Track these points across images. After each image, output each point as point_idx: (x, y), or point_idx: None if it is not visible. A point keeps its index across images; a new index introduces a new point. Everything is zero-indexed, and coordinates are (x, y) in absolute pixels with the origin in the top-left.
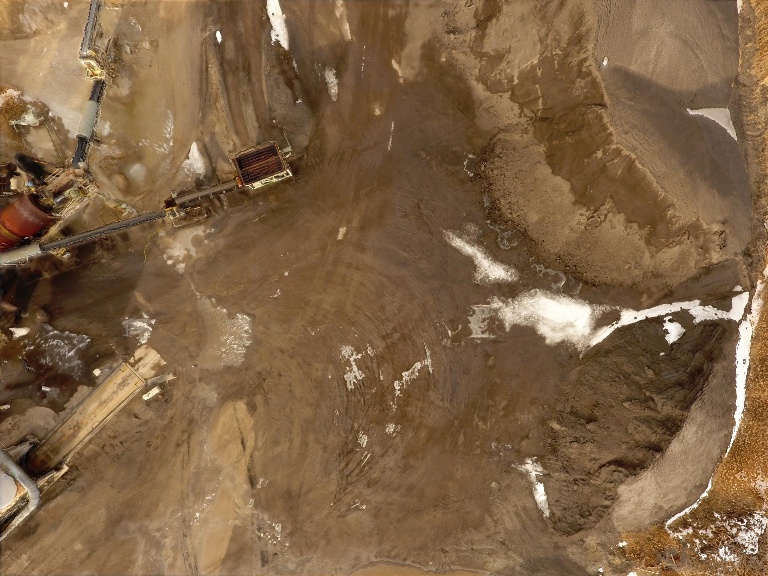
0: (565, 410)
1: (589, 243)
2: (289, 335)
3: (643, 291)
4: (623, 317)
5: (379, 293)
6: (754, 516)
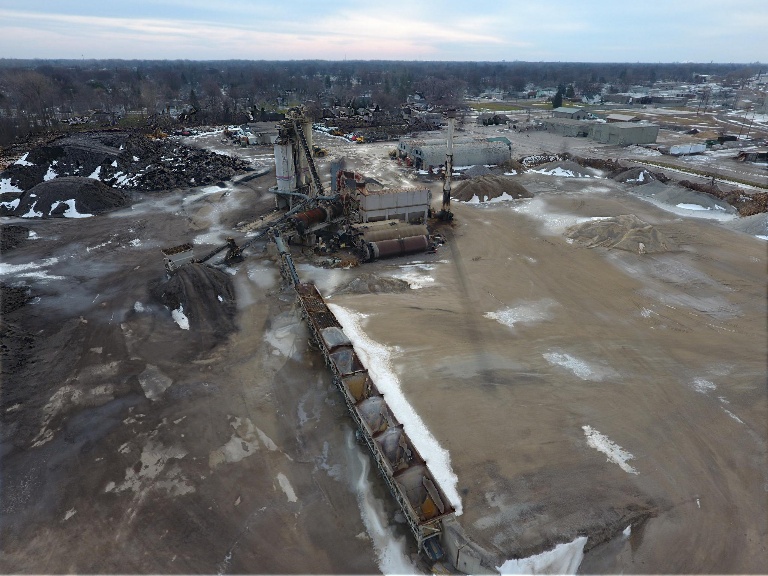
0: (5, 250)
1: None
2: None
3: None
4: None
5: None
6: None
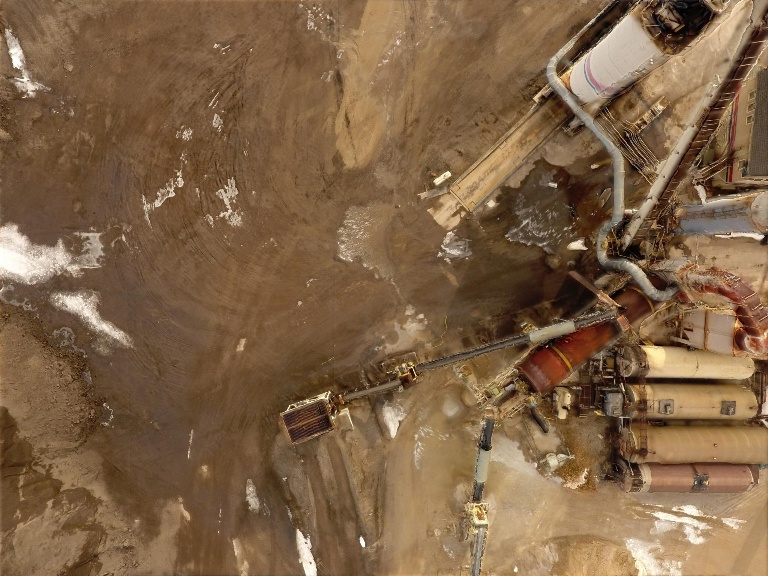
0: None
1: None
2: (297, 238)
3: None
4: None
5: (201, 282)
6: None
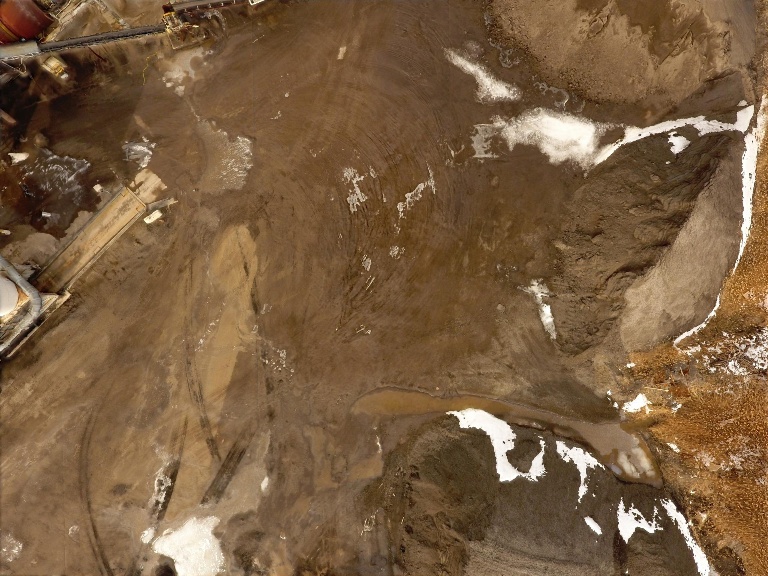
0: (570, 229)
1: (592, 54)
2: (291, 157)
3: (647, 108)
4: (627, 134)
5: (381, 113)
6: (763, 332)
